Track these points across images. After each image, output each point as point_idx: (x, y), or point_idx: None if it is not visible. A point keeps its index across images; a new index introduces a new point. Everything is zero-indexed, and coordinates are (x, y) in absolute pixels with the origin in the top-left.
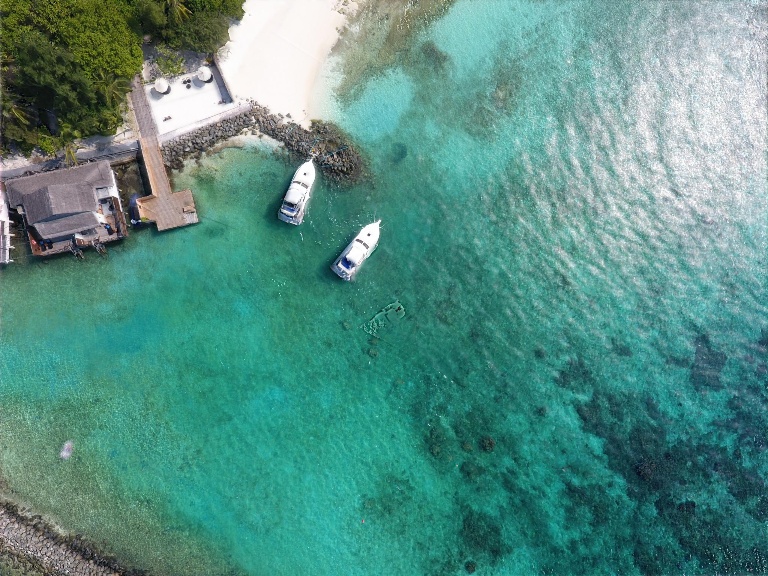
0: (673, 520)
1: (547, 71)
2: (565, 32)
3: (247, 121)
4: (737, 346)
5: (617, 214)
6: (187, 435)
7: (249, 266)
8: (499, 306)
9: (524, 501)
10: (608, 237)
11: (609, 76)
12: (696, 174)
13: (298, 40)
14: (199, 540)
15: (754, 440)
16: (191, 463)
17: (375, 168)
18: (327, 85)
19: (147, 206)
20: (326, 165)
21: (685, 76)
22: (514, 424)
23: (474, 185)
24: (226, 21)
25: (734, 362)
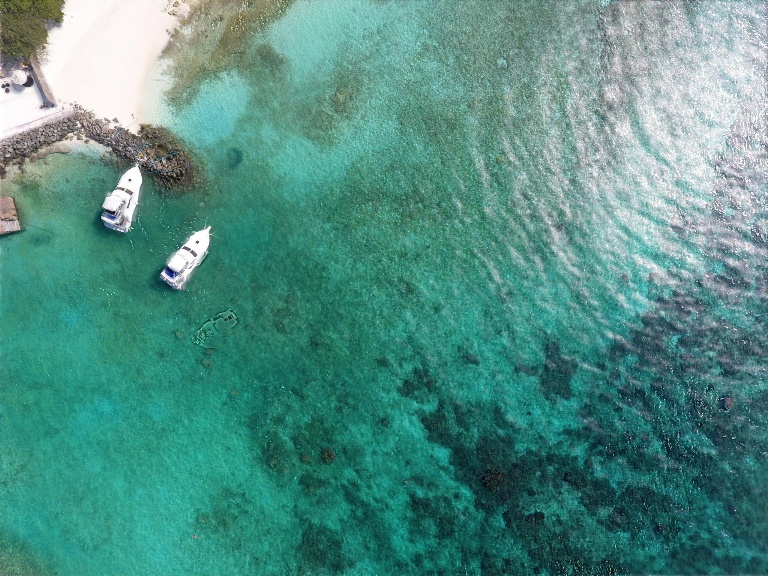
0: (521, 532)
1: (389, 73)
2: (408, 33)
3: (71, 126)
4: (589, 353)
5: (463, 219)
6: (11, 449)
7: (76, 275)
8: (340, 314)
9: (366, 514)
10: (454, 243)
11: (454, 78)
12: (545, 178)
13: (125, 42)
14: (23, 557)
15: (606, 449)
16: (15, 478)
17: (209, 173)
18: (157, 88)
19: None
20: (155, 171)
21: (533, 78)
22: (356, 435)
23: (313, 190)
24: (39, 23)
25: (585, 370)
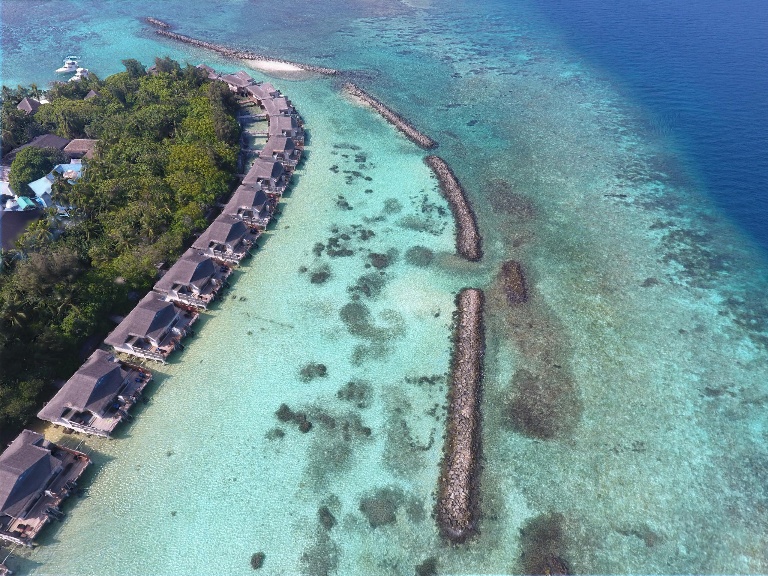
0: None
1: None
2: None
3: None
4: None
5: None
6: None
7: None
8: None
9: (57, 41)
10: None
11: None
12: None
13: None
14: None
15: None
16: None
17: (46, 83)
18: None
19: None
20: None
21: None
22: None
23: None
24: None
25: None
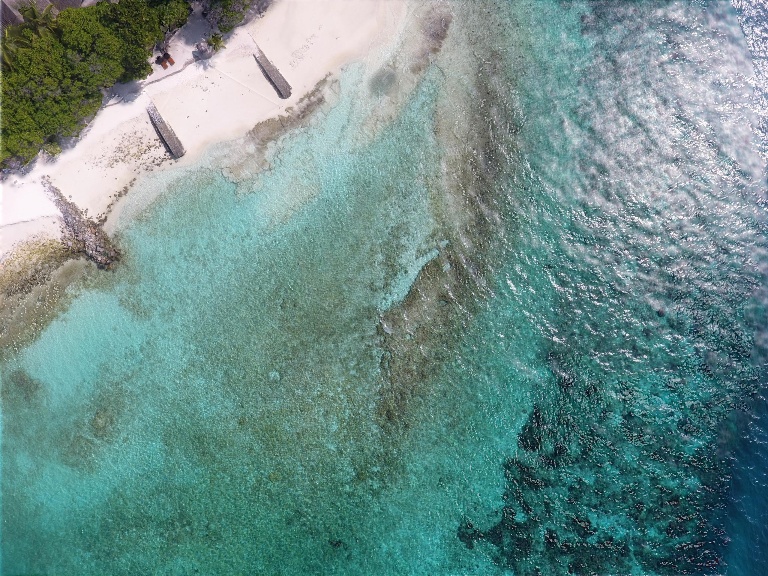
0: None
1: (153, 392)
2: (173, 349)
3: None
4: None
5: (234, 540)
6: None
7: None
8: None
9: None
10: (225, 565)
11: (223, 394)
12: (322, 492)
13: None
14: None
15: None
16: None
17: None
18: None
19: None
20: None
21: (308, 389)
22: None
23: (73, 518)
24: None
25: None
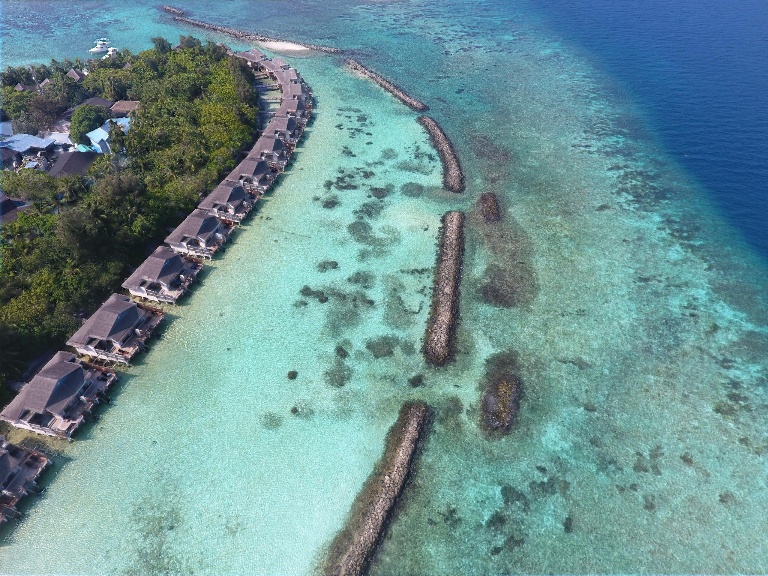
0: None
1: None
2: None
3: None
4: None
5: (1, 52)
6: None
7: None
8: None
9: None
10: None
11: None
12: None
13: None
14: (183, 29)
15: None
16: None
17: (81, 61)
18: None
19: None
20: None
21: None
22: None
23: None
24: None
25: None
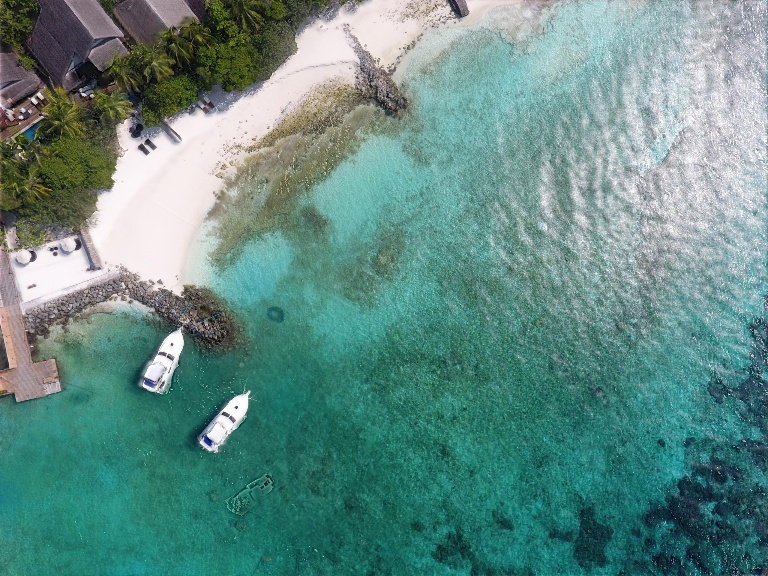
0: None
1: (431, 235)
2: (450, 195)
3: (116, 287)
4: (624, 519)
5: (501, 381)
6: None
7: (114, 434)
8: (375, 476)
9: None
10: (491, 405)
11: (495, 240)
12: (583, 340)
13: (173, 205)
14: None
15: None
16: None
17: (249, 333)
18: (202, 249)
19: (6, 377)
20: (196, 333)
21: (573, 241)
22: None
23: (352, 351)
24: (91, 195)
25: (621, 536)
